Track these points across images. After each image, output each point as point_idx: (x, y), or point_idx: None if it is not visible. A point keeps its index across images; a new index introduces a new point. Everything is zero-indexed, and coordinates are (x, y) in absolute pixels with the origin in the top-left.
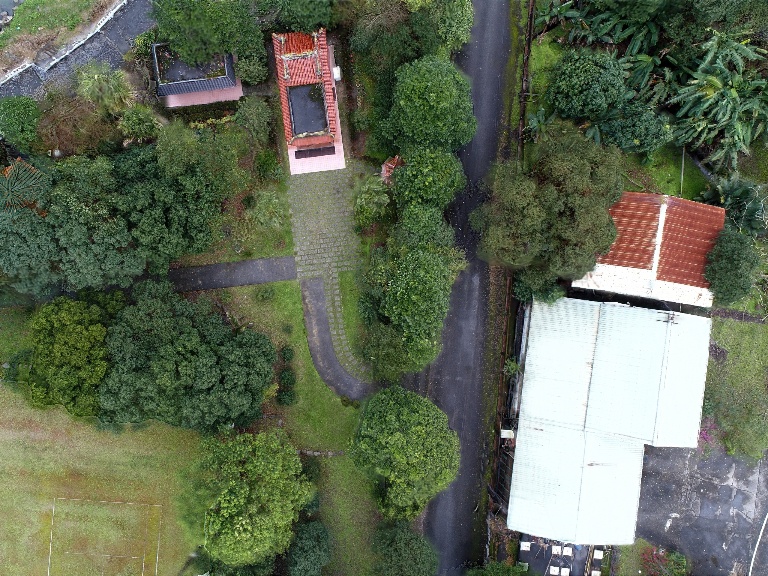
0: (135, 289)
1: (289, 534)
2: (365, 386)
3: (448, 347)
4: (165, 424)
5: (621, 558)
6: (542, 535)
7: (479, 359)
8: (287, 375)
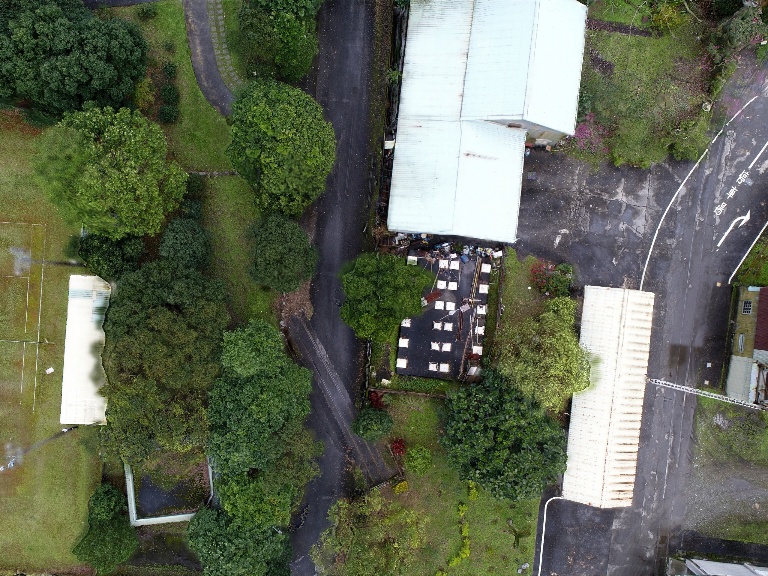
0: None
1: (159, 217)
2: None
3: (334, 69)
4: (48, 143)
5: (510, 275)
6: (421, 230)
7: (366, 80)
8: (169, 89)
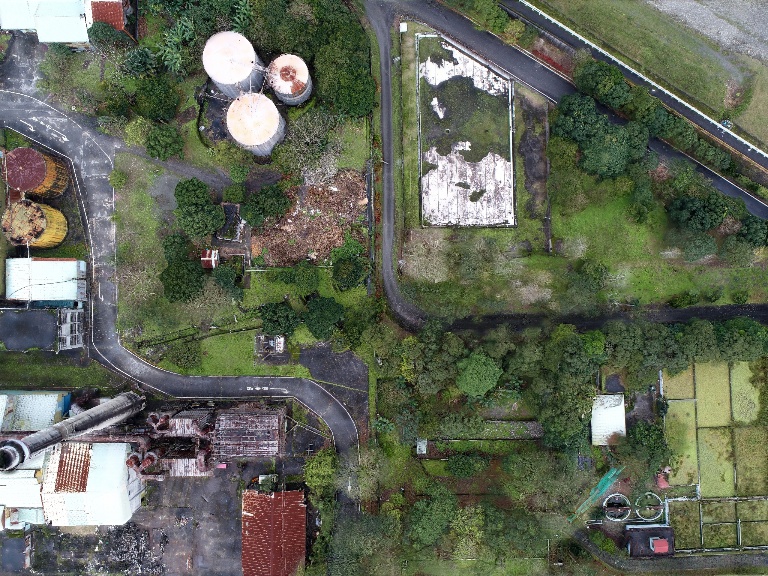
0: None
1: None
2: None
3: None
4: None
5: None
6: None
7: None
8: None
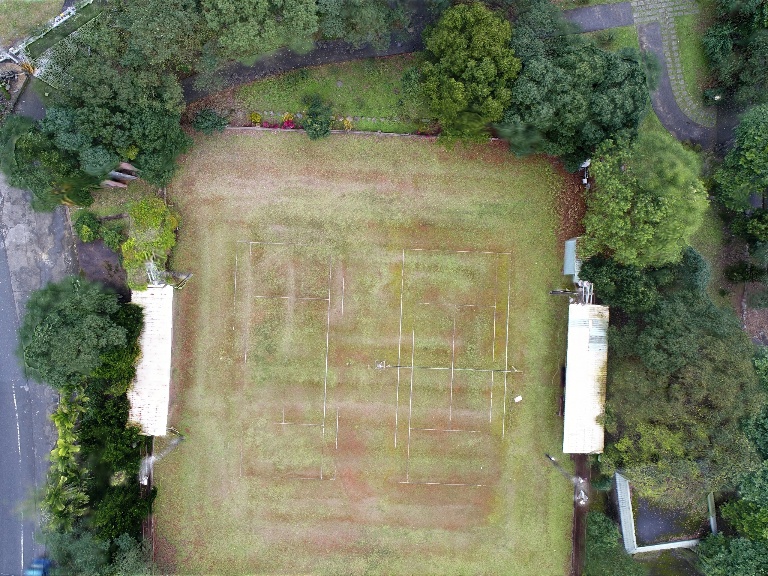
0: (523, 1)
1: (681, 246)
2: (706, 130)
3: None
4: (511, 172)
5: None
6: None
7: None
8: (634, 116)
